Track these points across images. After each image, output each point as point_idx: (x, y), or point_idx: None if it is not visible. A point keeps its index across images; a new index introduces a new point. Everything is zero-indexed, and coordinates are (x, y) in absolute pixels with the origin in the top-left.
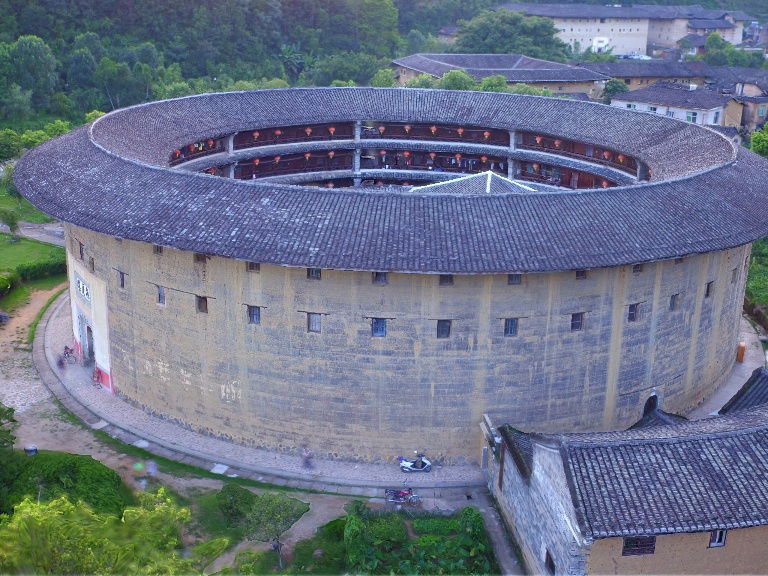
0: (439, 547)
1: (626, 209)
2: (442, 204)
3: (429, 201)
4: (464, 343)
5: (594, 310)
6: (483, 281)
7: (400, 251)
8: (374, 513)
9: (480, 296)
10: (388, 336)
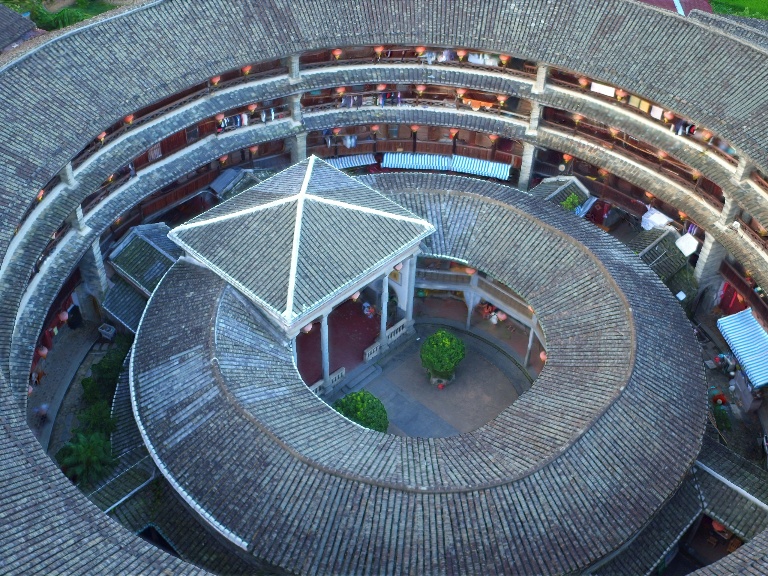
0: None
1: None
2: None
3: None
4: None
5: None
6: None
7: None
8: None
9: None
10: None
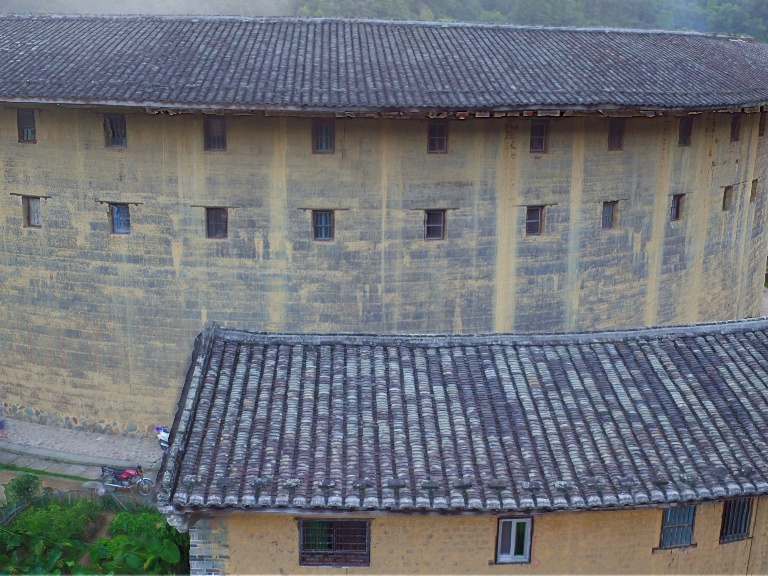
0: (99, 550)
1: (515, 48)
2: (216, 29)
3: (199, 25)
4: (248, 247)
5: (463, 207)
6: (272, 145)
7: (114, 77)
8: (59, 498)
9: (268, 170)
10: (133, 232)
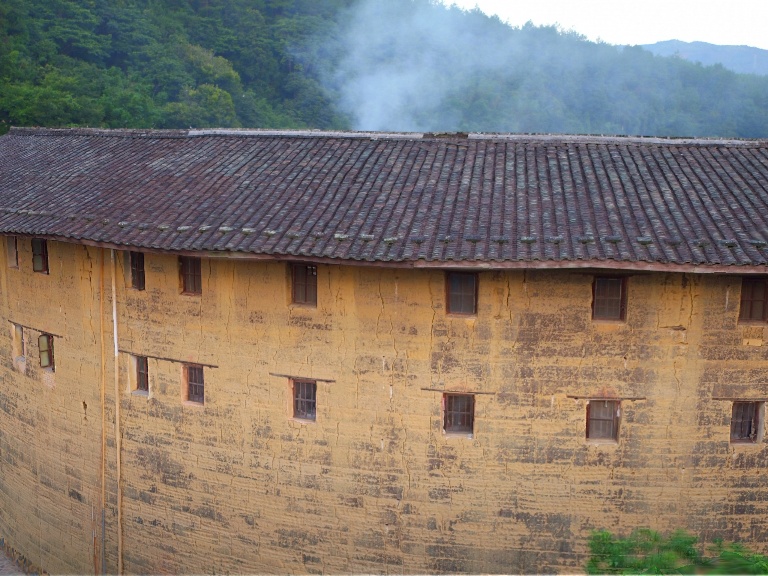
0: None
1: None
2: None
3: None
4: None
5: None
6: None
7: None
8: None
9: None
10: None
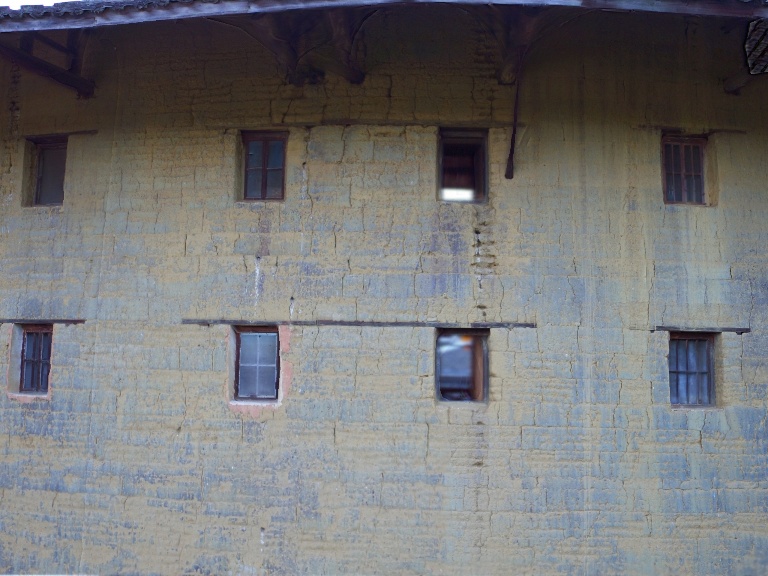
0: None
1: None
2: None
3: None
4: None
5: None
6: None
7: None
8: None
9: None
10: None
